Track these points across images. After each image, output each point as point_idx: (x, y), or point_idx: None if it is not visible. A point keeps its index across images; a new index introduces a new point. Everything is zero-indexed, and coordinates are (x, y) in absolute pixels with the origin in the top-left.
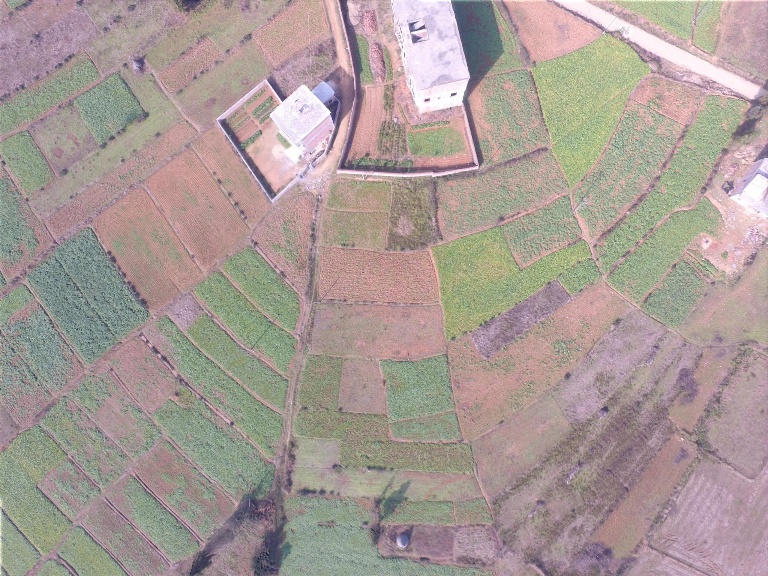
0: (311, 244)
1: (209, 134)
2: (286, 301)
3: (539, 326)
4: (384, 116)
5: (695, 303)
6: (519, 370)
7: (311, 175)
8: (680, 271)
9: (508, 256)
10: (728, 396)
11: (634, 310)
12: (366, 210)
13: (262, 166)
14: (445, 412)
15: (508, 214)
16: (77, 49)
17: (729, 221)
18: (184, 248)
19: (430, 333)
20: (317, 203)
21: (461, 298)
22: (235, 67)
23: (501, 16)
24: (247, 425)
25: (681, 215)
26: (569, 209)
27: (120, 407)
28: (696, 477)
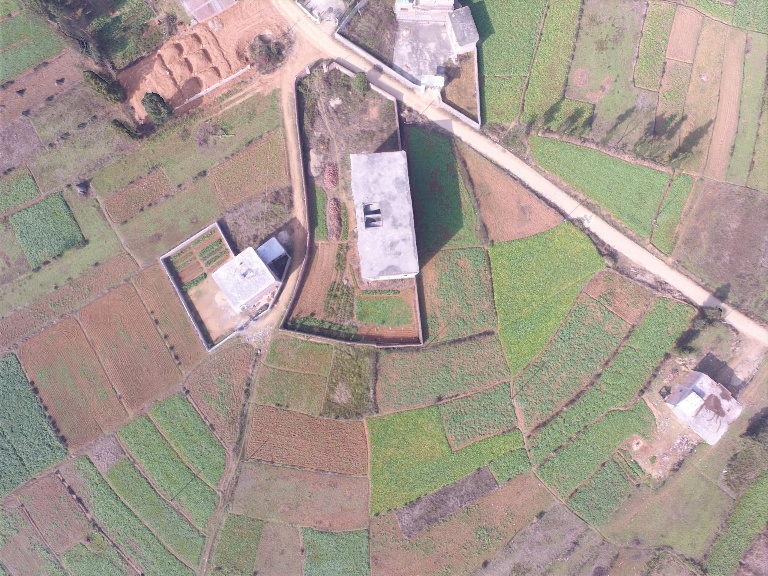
0: (244, 400)
1: (151, 270)
2: (212, 455)
3: (464, 510)
4: (334, 276)
5: (618, 503)
6: (438, 553)
7: (253, 327)
8: (608, 470)
9: (442, 437)
10: None
11: (559, 504)
12: (305, 371)
13: (203, 311)
14: None
15: (447, 395)
16: (18, 163)
17: (662, 426)
18: (112, 387)
19: (354, 506)
20: (255, 357)
21: (389, 475)
22: (186, 204)
23: (465, 188)
24: None
25: (616, 415)
26: (508, 397)
27: (27, 545)
28: None
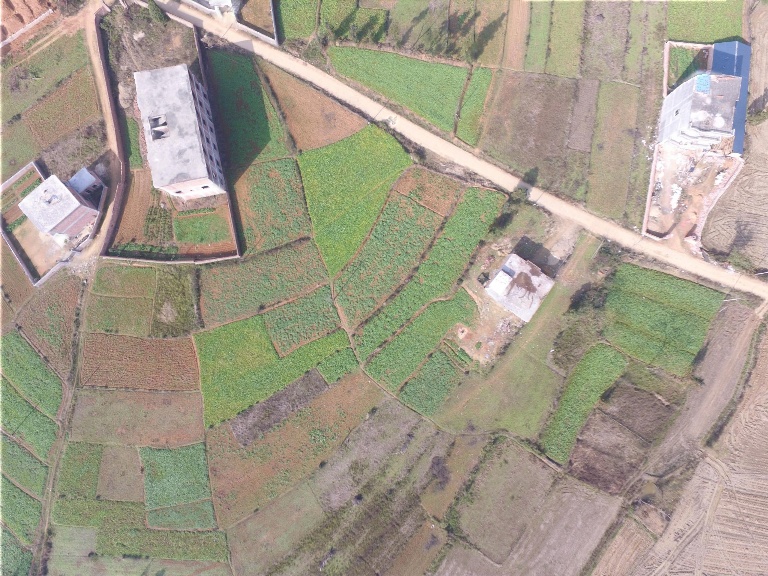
0: (74, 329)
1: None
2: (48, 387)
3: (297, 414)
4: (151, 201)
5: (449, 392)
6: (275, 458)
7: (77, 259)
8: (436, 360)
9: (268, 345)
10: (481, 482)
11: (390, 399)
12: (131, 296)
13: (28, 249)
14: (201, 500)
15: (269, 303)
16: None
17: (483, 312)
18: None
19: (189, 421)
20: (83, 288)
21: (220, 386)
22: (3, 147)
23: (270, 103)
24: (4, 513)
25: (438, 305)
26: (329, 298)
27: None
28: (448, 562)
